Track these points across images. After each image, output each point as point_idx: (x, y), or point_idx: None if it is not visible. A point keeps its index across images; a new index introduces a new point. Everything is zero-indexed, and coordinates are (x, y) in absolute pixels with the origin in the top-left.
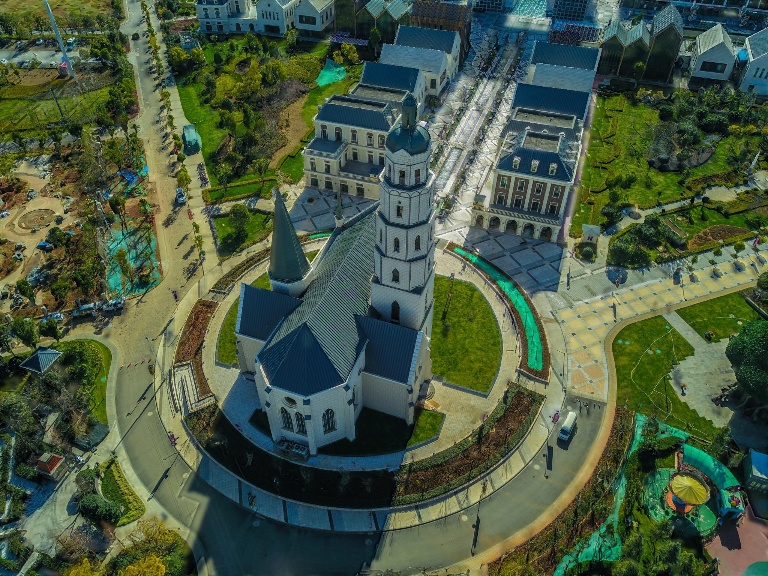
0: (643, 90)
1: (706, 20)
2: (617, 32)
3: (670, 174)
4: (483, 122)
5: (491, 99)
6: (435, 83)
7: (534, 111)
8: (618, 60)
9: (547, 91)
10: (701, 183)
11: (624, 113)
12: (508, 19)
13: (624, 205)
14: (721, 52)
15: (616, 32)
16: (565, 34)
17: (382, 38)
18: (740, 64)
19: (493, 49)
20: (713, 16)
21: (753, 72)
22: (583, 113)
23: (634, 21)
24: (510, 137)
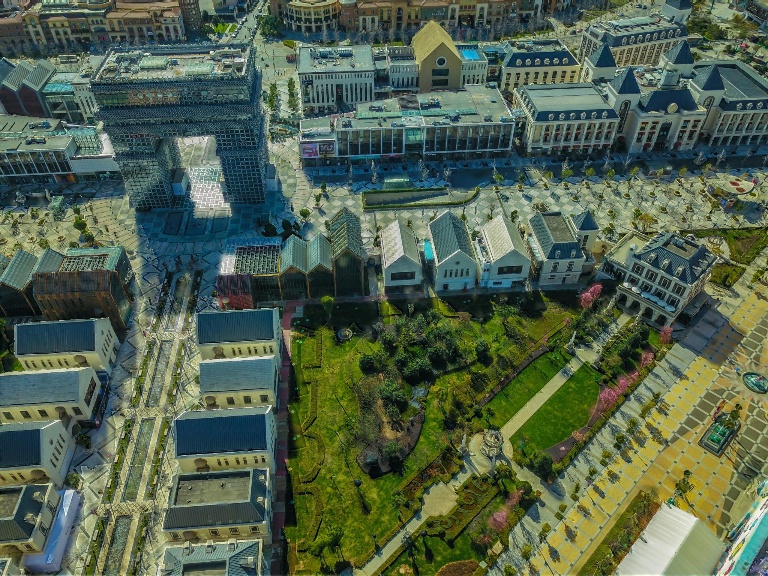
0: (330, 368)
1: (389, 178)
2: (293, 259)
3: (383, 480)
4: (156, 444)
5: (165, 390)
6: (79, 410)
7: (200, 475)
8: (304, 285)
9: (214, 423)
10: (417, 486)
11: (323, 370)
12: (180, 218)
13: (338, 570)
14: (405, 263)
15: (291, 261)
16: (234, 279)
17: (12, 309)
18: (429, 262)
19: (164, 283)
20: (397, 163)
21: (442, 274)
22: (265, 441)
23: (318, 198)
24: (164, 572)
